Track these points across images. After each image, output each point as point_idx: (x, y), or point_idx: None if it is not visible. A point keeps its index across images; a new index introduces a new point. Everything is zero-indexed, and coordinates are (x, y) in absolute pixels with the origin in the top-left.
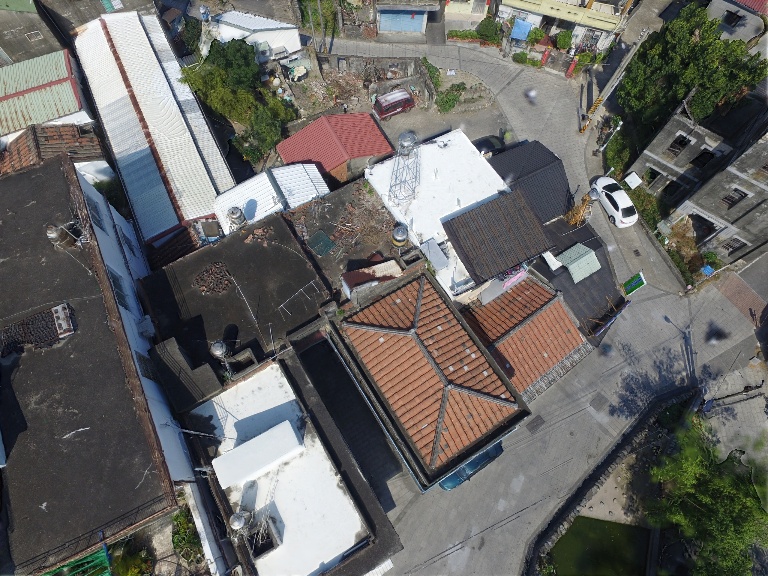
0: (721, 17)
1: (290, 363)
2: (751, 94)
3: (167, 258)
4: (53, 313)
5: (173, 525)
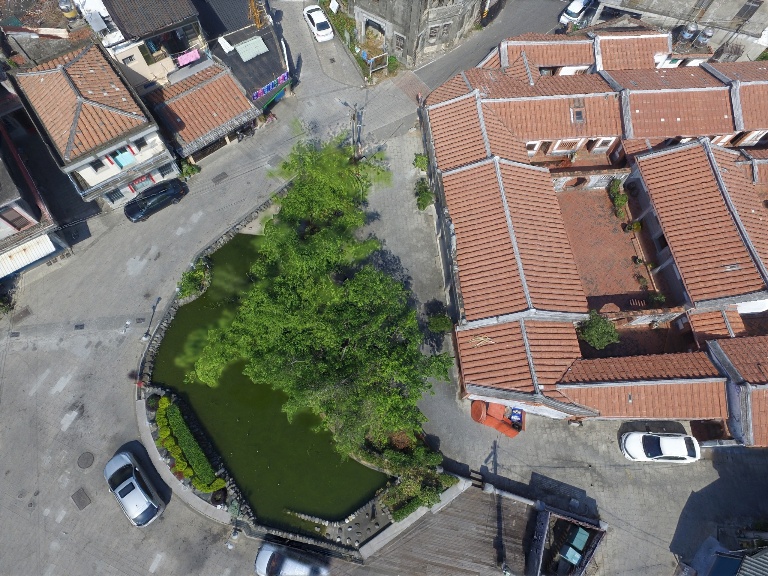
0: None
1: None
2: None
3: None
4: None
5: None
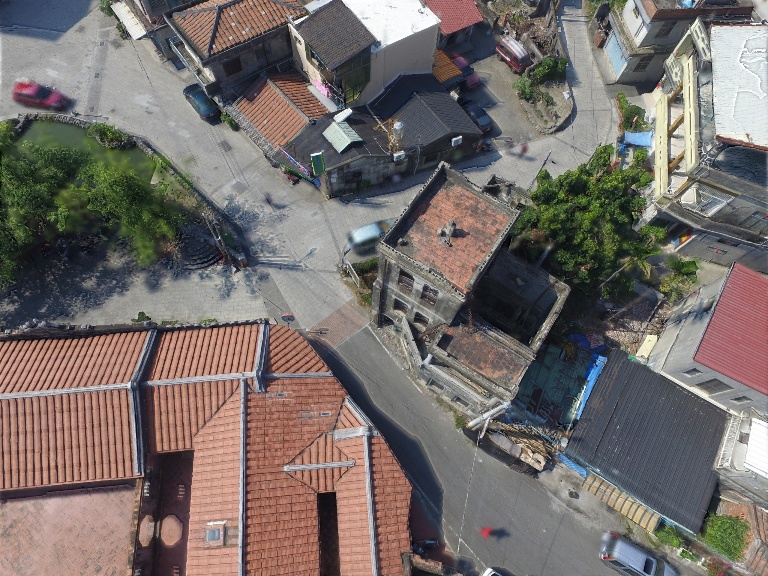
0: (712, 298)
1: None
2: (544, 253)
3: None
4: None
5: None
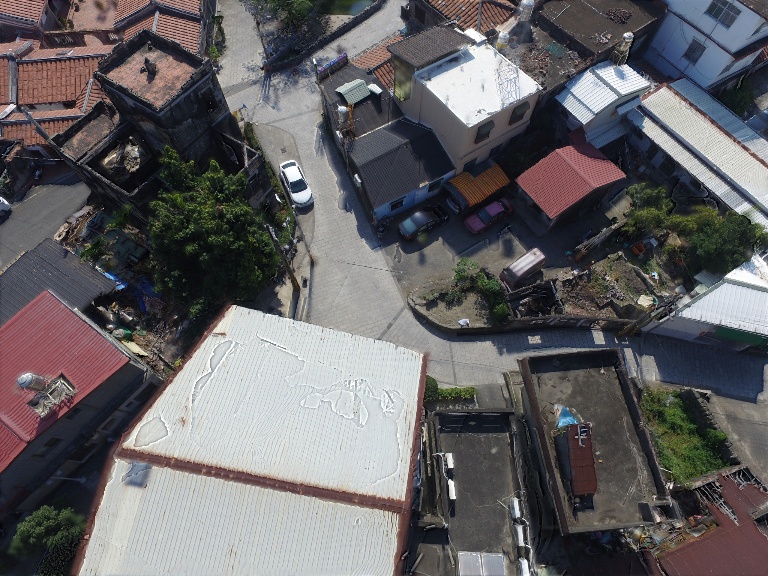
0: None
1: None
2: None
3: (662, 77)
4: None
5: None
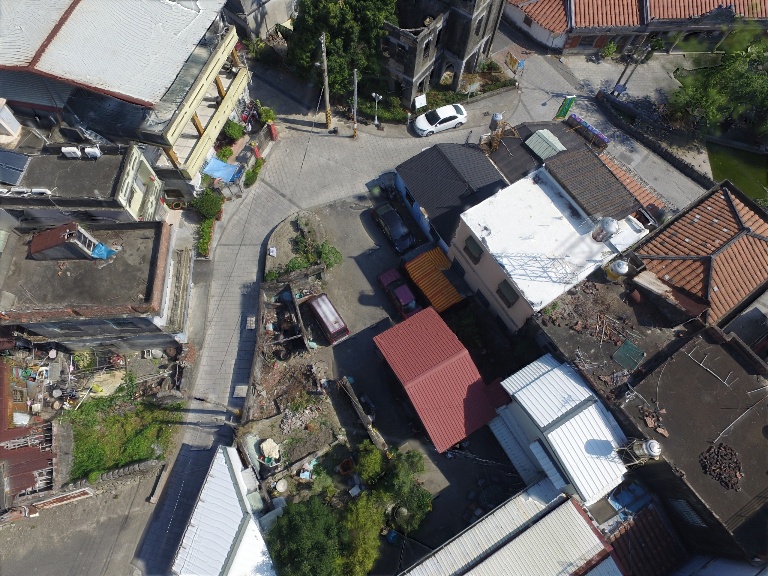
0: None
1: None
2: None
3: (643, 568)
4: None
5: None
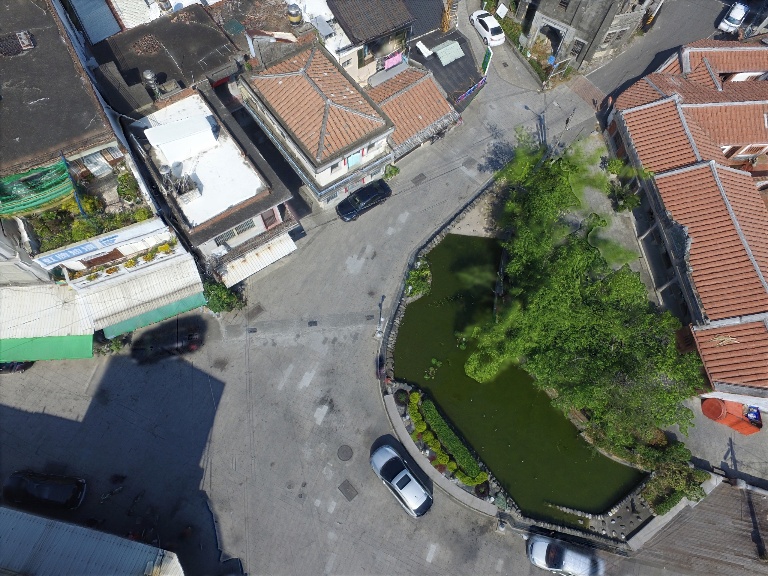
0: None
1: (208, 94)
2: None
3: None
4: (17, 36)
5: (118, 184)
